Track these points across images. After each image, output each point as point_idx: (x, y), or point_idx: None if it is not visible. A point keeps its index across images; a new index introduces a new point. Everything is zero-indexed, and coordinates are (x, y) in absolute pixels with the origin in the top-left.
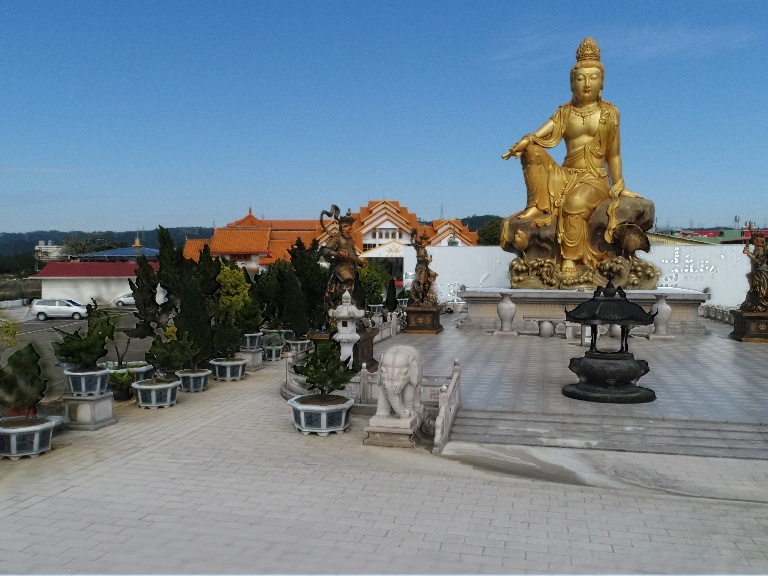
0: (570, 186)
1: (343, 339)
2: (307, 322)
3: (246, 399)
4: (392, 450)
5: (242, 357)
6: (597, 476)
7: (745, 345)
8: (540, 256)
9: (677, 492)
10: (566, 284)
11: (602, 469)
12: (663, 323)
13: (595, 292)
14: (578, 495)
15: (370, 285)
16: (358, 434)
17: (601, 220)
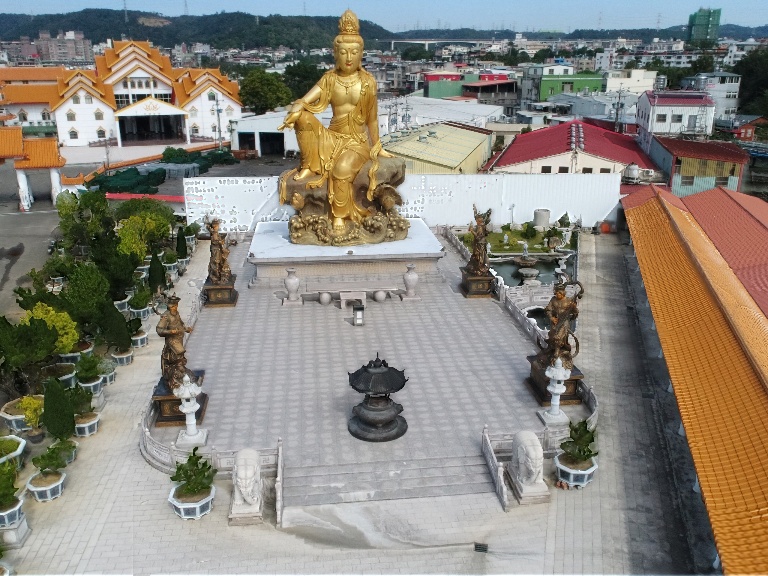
0: (337, 151)
1: (188, 412)
2: (129, 339)
3: (118, 470)
4: (250, 530)
5: None
6: (376, 535)
7: (468, 305)
8: (314, 211)
9: (418, 544)
10: (337, 242)
11: (378, 526)
12: (412, 288)
13: (368, 365)
14: (367, 561)
15: (158, 232)
16: (221, 511)
17: (364, 181)
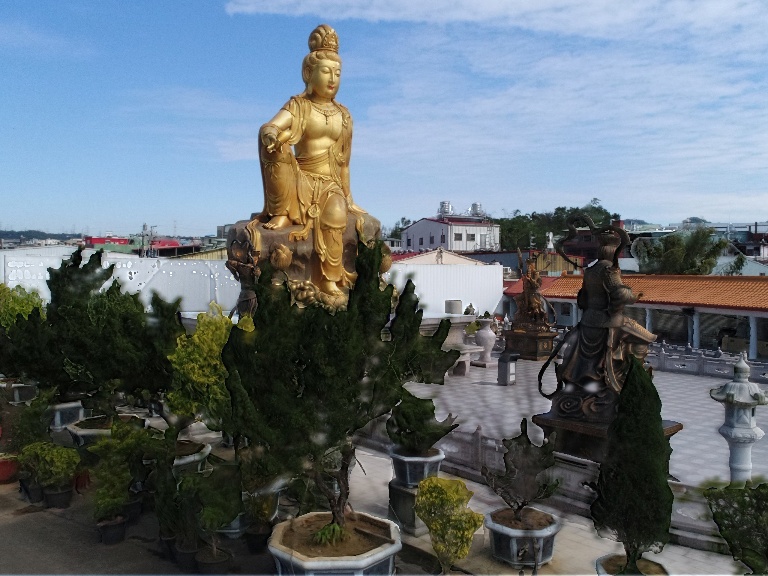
0: (319, 194)
1: (761, 436)
2: None
3: None
4: None
5: None
6: None
7: None
8: (291, 276)
9: None
10: None
11: None
12: None
13: None
14: None
15: None
16: None
17: (352, 236)
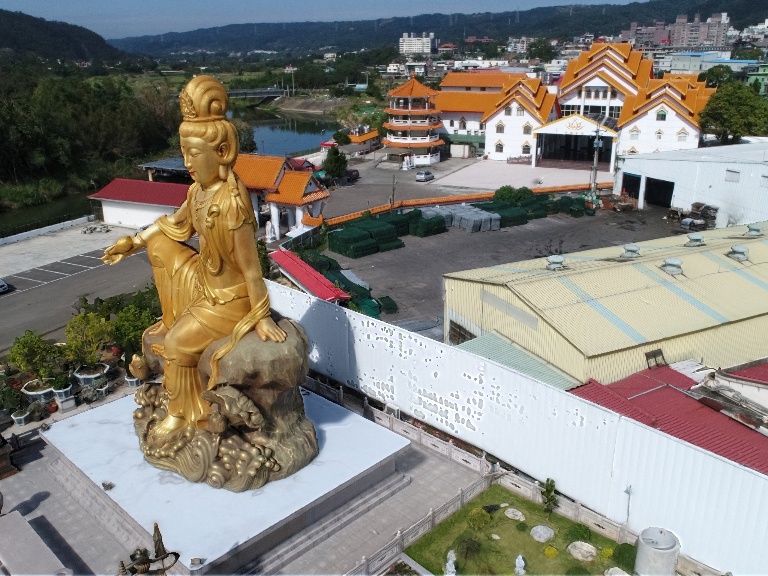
0: None
1: None
2: None
3: None
4: None
5: None
6: None
7: None
8: None
9: None
10: None
11: None
12: None
13: None
14: None
15: (128, 335)
16: None
17: (206, 370)
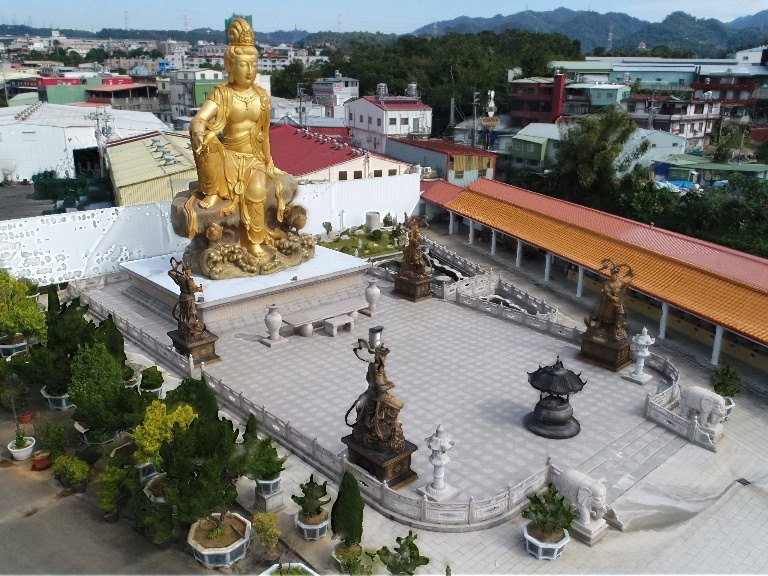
0: (244, 172)
1: None
2: None
3: None
4: (609, 542)
5: (274, 500)
6: (684, 504)
7: (428, 308)
8: (224, 241)
9: (713, 497)
10: (267, 270)
11: (673, 497)
12: None
13: (553, 369)
14: (712, 523)
15: None
16: None
17: (272, 202)
